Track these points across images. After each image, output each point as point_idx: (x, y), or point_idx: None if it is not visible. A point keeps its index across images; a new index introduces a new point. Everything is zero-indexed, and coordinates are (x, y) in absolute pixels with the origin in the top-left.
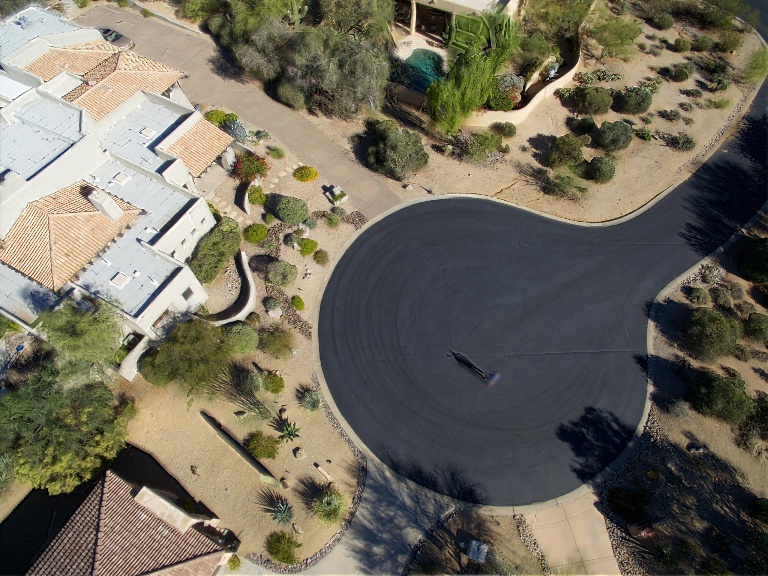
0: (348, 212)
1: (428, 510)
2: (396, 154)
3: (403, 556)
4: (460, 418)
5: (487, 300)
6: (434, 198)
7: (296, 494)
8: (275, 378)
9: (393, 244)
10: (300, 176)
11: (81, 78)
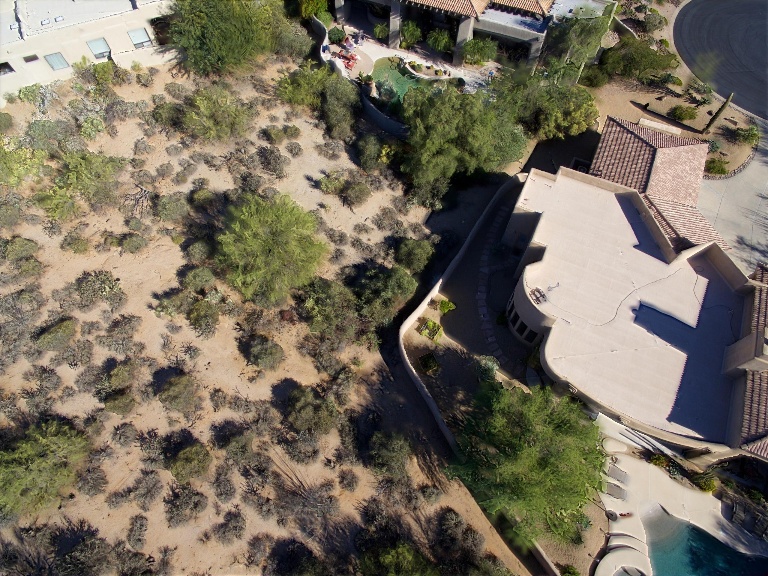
0: None
1: None
2: None
3: None
4: None
5: None
6: None
7: (717, 136)
8: (677, 77)
9: (707, 14)
10: None
11: None
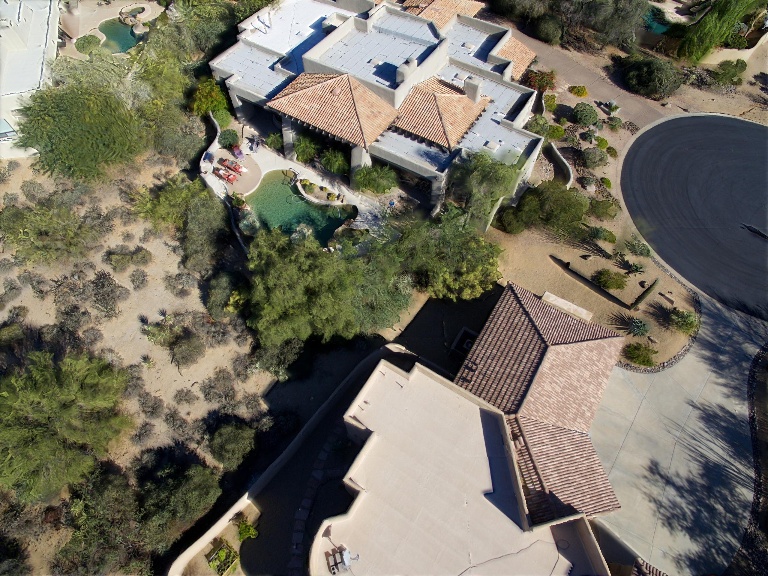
0: (622, 121)
1: (760, 332)
2: (663, 75)
3: (747, 363)
4: (767, 271)
5: (761, 190)
6: (690, 115)
7: (647, 315)
8: (610, 232)
9: (668, 146)
10: (577, 92)
11: (402, 5)
